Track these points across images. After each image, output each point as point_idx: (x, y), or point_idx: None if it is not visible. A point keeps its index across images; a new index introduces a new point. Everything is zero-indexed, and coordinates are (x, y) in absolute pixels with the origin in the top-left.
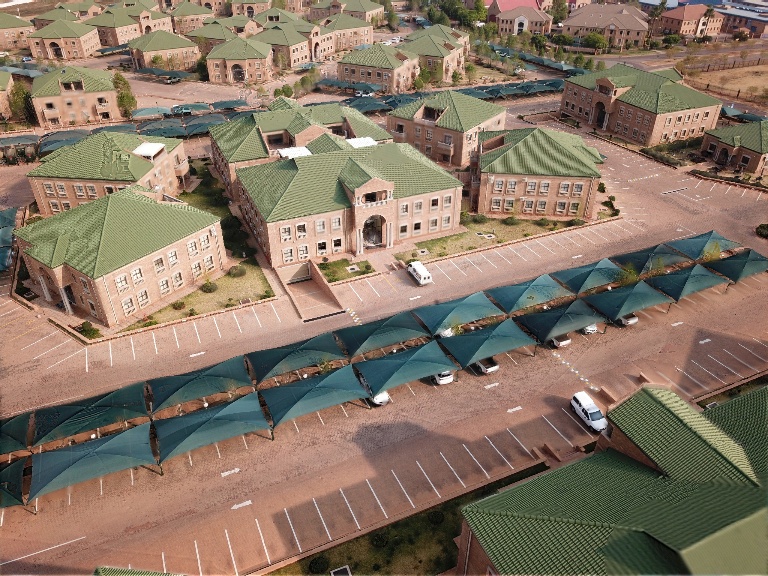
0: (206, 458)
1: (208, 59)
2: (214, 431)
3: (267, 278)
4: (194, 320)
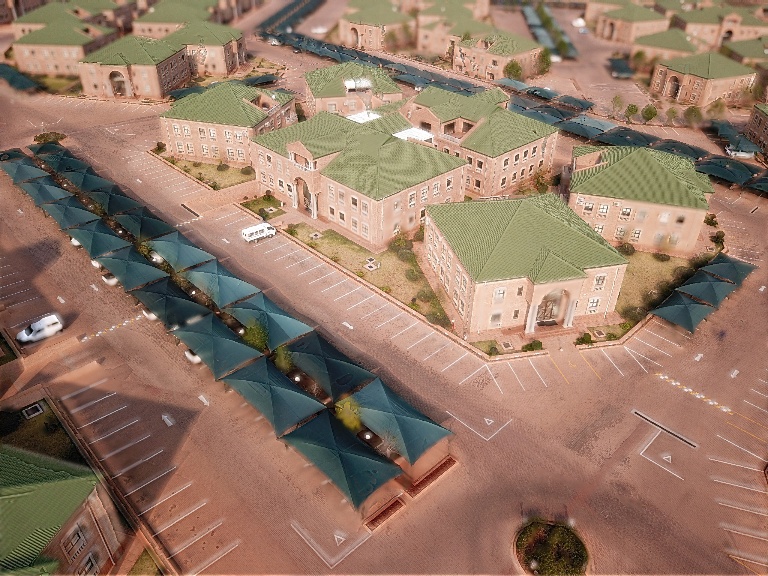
0: (34, 203)
1: (656, 63)
2: (33, 188)
3: (244, 183)
4: (177, 171)
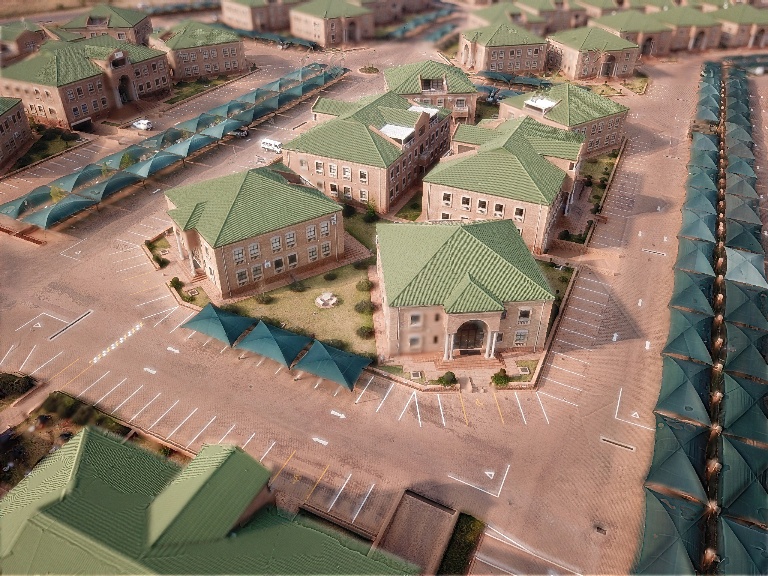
0: None
1: None
2: None
3: None
4: None
